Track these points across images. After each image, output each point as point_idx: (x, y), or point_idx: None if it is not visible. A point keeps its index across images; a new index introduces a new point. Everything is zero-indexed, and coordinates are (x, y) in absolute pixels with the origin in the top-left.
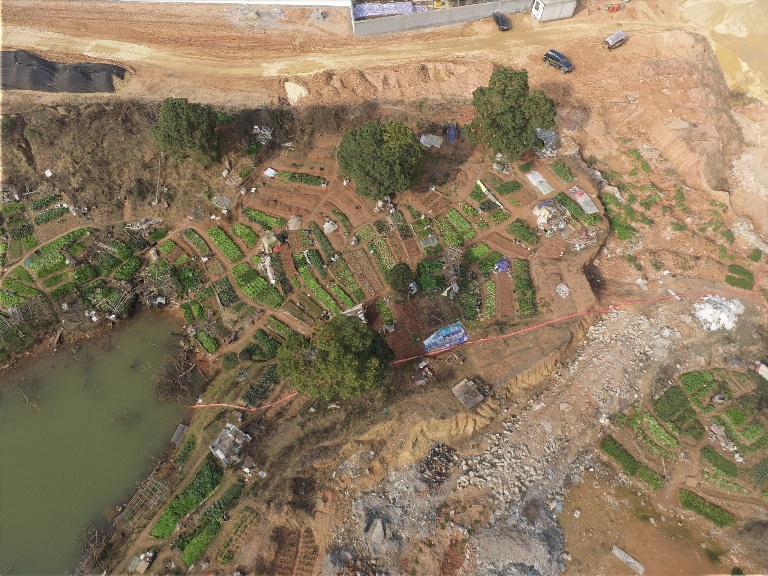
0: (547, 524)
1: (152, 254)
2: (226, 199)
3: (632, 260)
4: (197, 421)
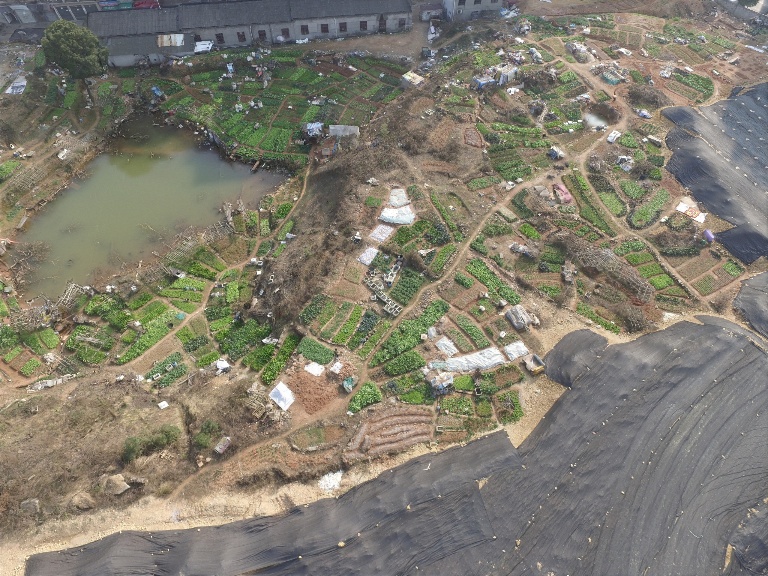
0: None
1: (51, 357)
2: None
3: None
4: (5, 229)
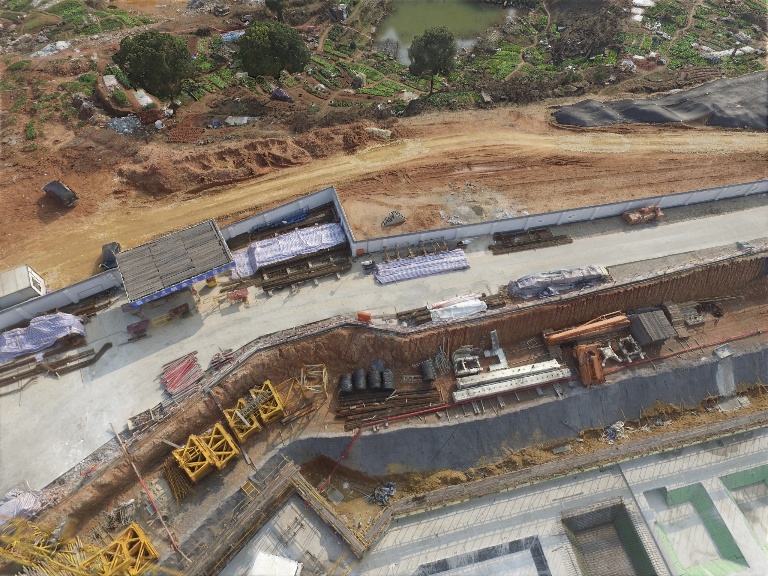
0: (193, 5)
1: None
2: None
3: (94, 64)
4: None
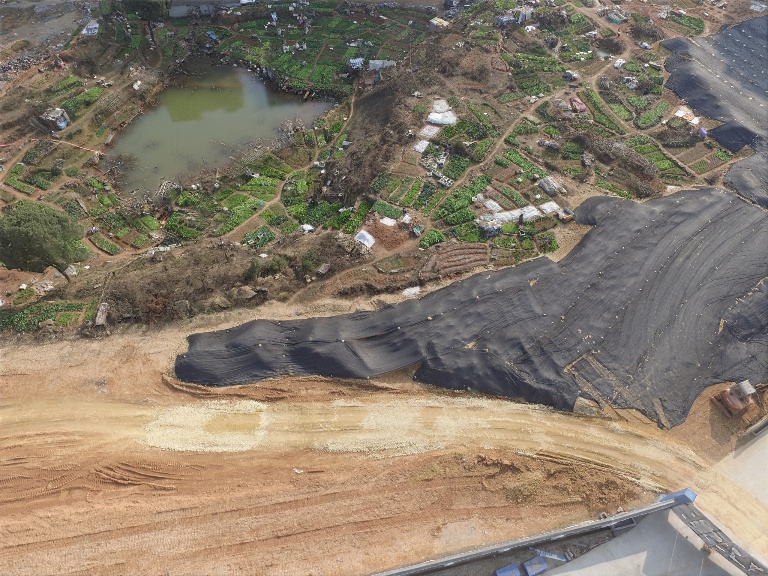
0: None
1: None
2: (61, 274)
3: None
4: (96, 143)
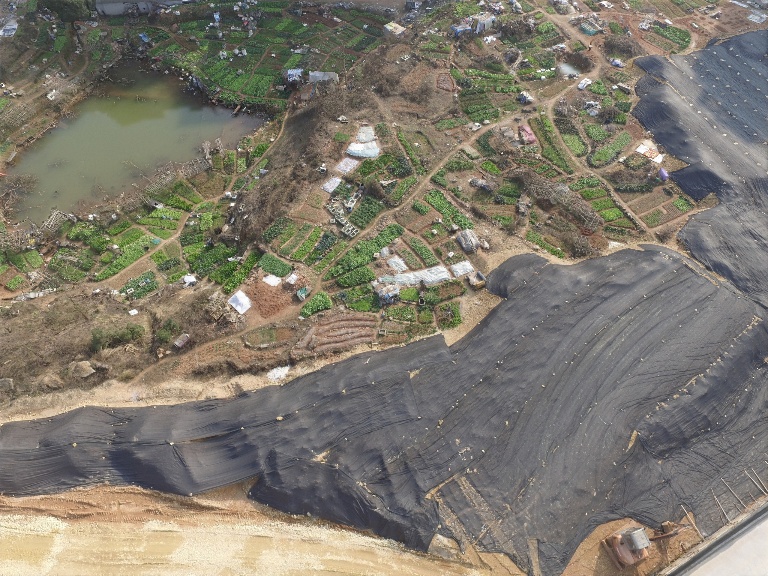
0: None
1: (35, 274)
2: None
3: None
4: None
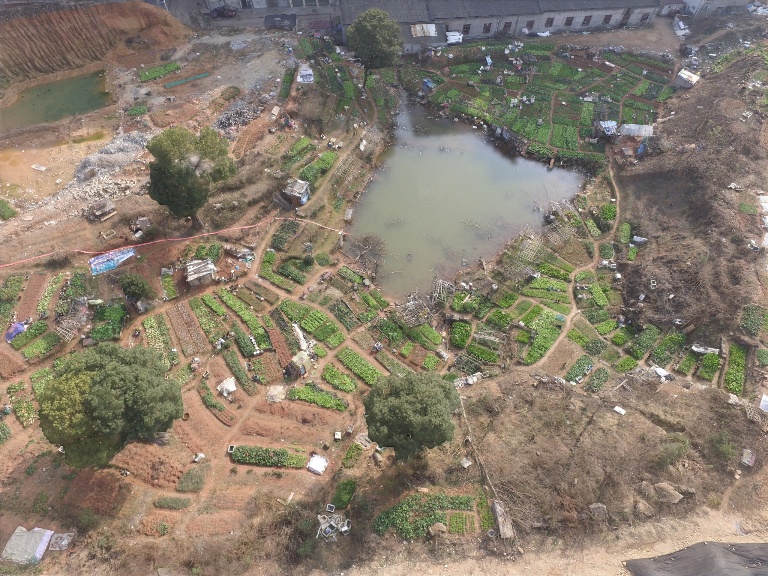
0: (82, 172)
1: (444, 353)
2: None
3: None
4: (337, 220)
